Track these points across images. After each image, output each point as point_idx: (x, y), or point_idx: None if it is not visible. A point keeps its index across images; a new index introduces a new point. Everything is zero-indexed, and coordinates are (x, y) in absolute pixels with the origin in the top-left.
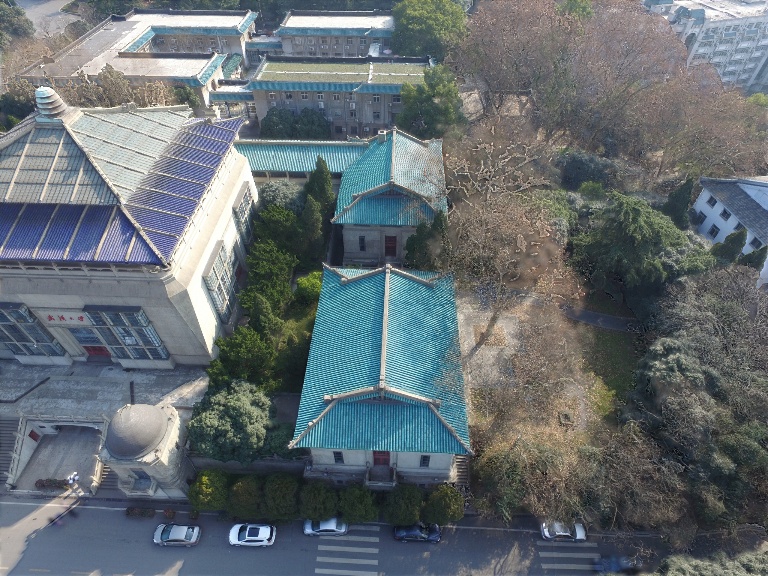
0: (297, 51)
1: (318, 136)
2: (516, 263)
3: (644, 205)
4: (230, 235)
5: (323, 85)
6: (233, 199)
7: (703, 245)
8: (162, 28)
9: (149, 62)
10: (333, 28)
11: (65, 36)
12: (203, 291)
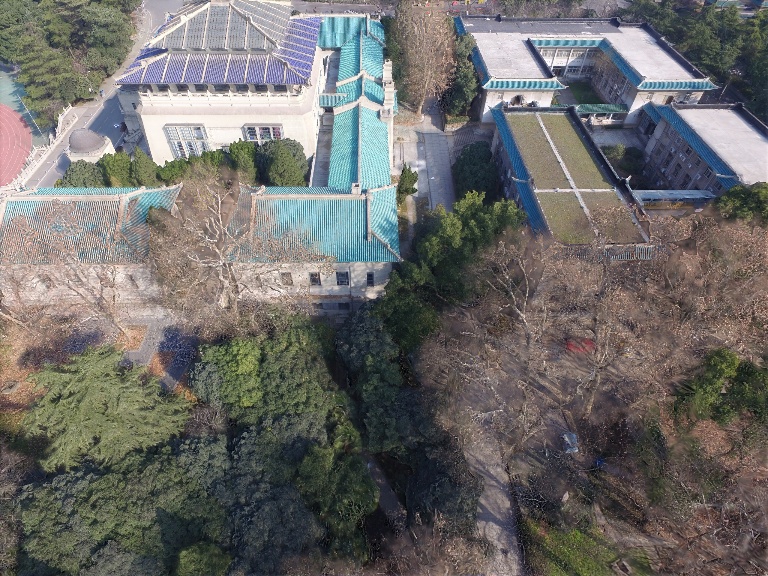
0: (663, 142)
1: (465, 189)
2: (197, 352)
3: (86, 393)
4: (230, 136)
5: (516, 154)
6: (251, 121)
7: (87, 568)
8: (608, 44)
9: (521, 55)
10: (705, 143)
11: (561, 14)
12: (165, 133)
